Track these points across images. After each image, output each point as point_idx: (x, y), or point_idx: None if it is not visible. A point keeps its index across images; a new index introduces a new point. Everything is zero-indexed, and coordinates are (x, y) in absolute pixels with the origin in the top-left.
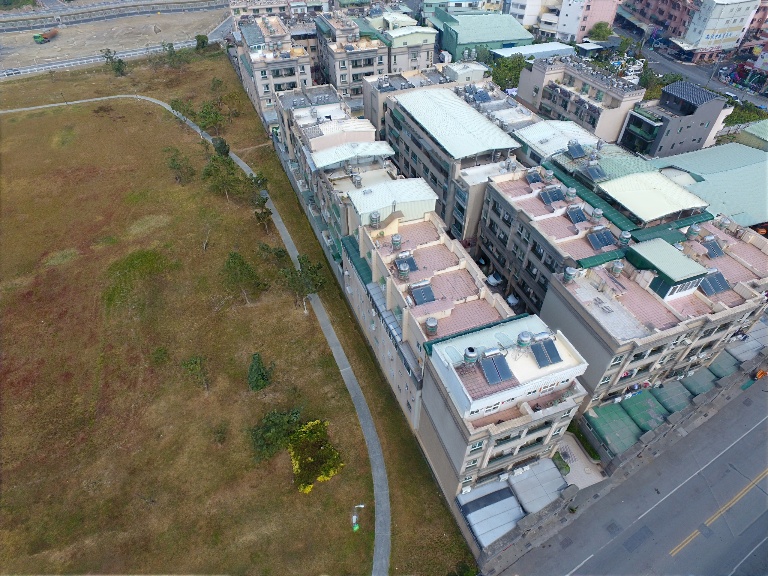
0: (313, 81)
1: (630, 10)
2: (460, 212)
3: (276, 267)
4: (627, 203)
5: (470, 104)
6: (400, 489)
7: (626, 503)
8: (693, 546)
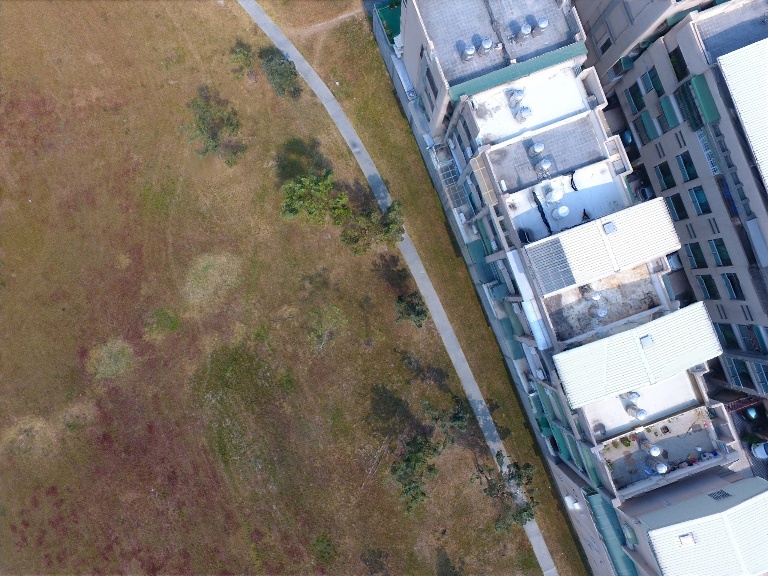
0: None
1: None
2: (767, 383)
3: (436, 388)
4: None
5: None
6: None
7: None
8: None
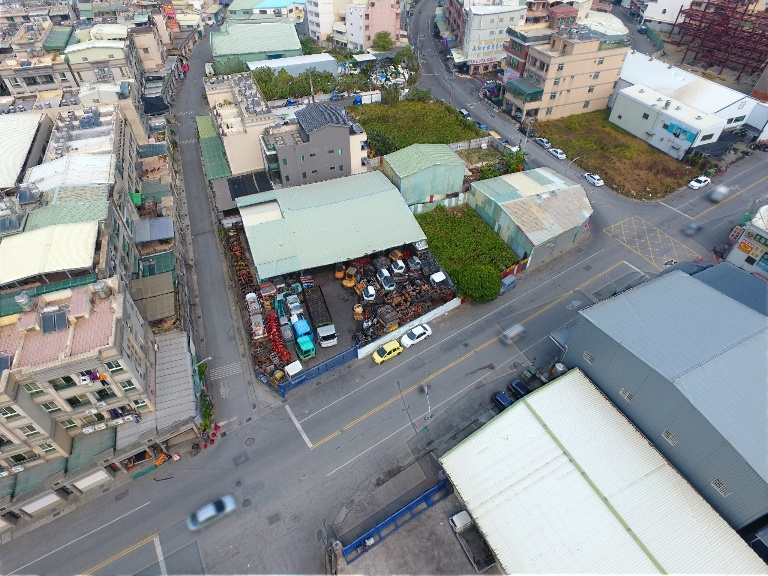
0: None
1: (444, 18)
2: None
3: None
4: None
5: None
6: None
7: None
8: None
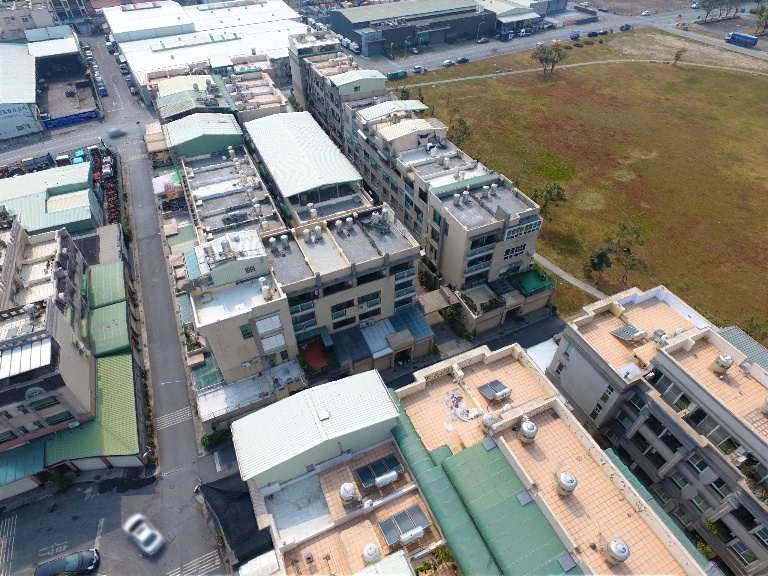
0: None
1: None
2: None
3: None
4: None
5: None
6: None
7: None
8: None
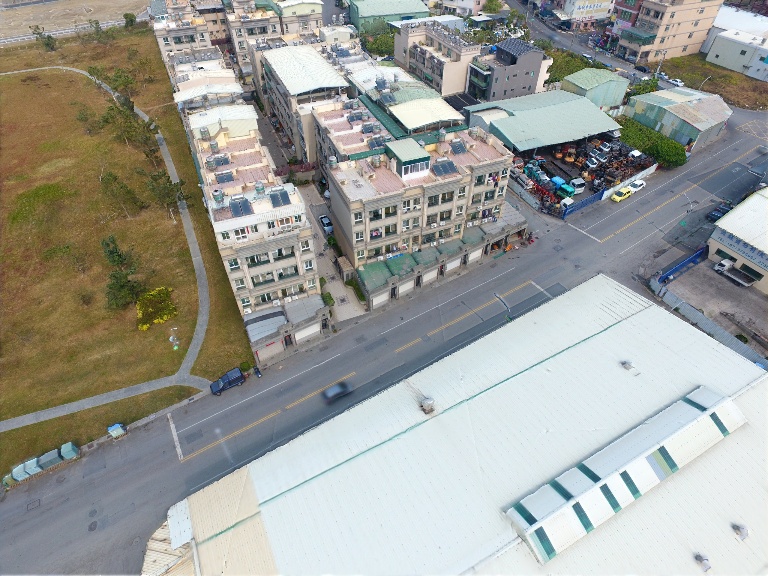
0: (226, 52)
1: None
2: (302, 140)
3: None
4: (403, 118)
5: (331, 59)
6: (216, 326)
7: (376, 325)
8: (413, 347)
